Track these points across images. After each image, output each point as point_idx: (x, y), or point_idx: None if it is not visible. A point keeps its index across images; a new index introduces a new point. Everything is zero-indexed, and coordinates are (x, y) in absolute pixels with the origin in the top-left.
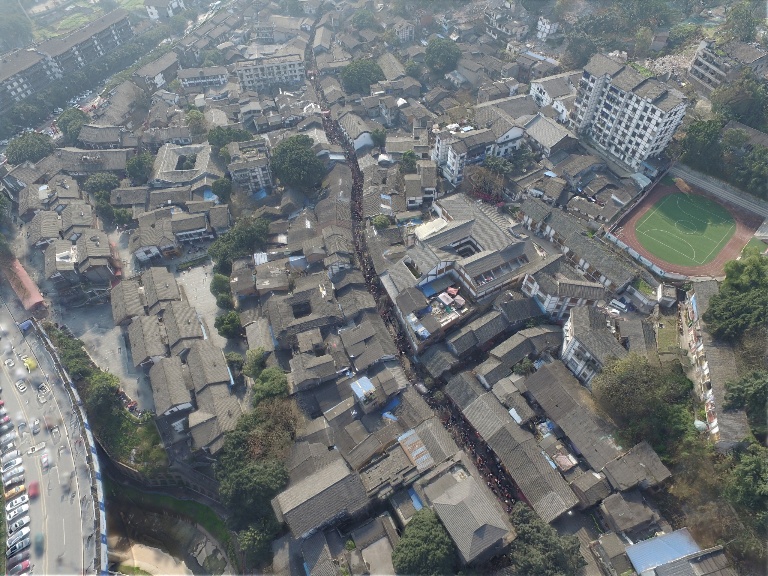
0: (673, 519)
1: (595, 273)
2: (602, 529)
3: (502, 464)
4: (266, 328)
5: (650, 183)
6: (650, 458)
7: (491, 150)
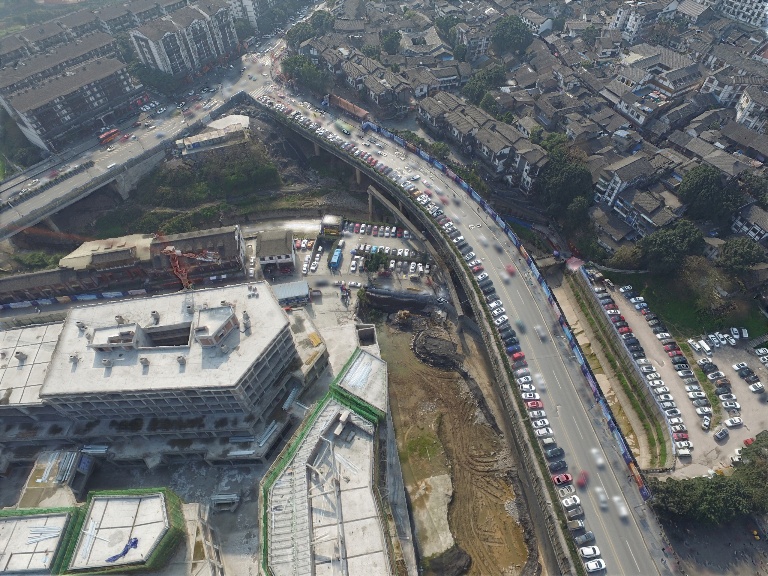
0: None
1: None
2: None
3: None
4: (533, 120)
5: None
6: None
7: (658, 17)
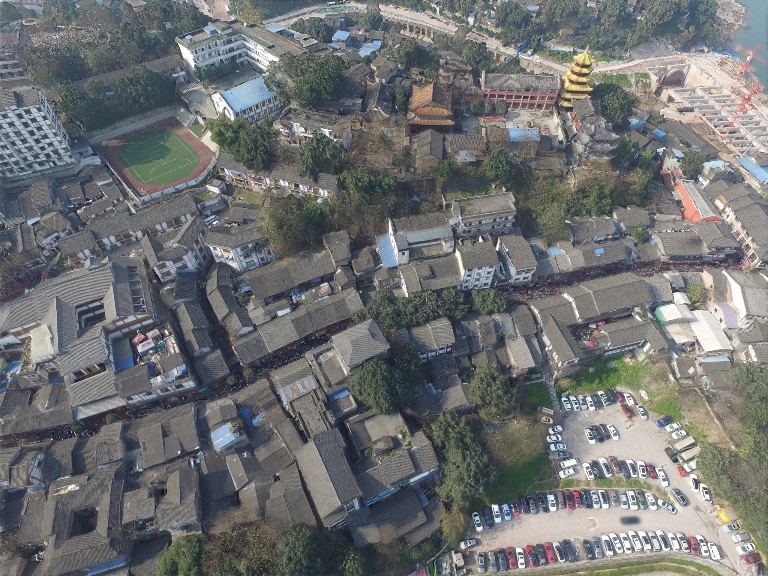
0: (369, 242)
1: (175, 222)
2: (370, 283)
3: (317, 335)
4: None
5: (99, 157)
6: (334, 236)
7: None
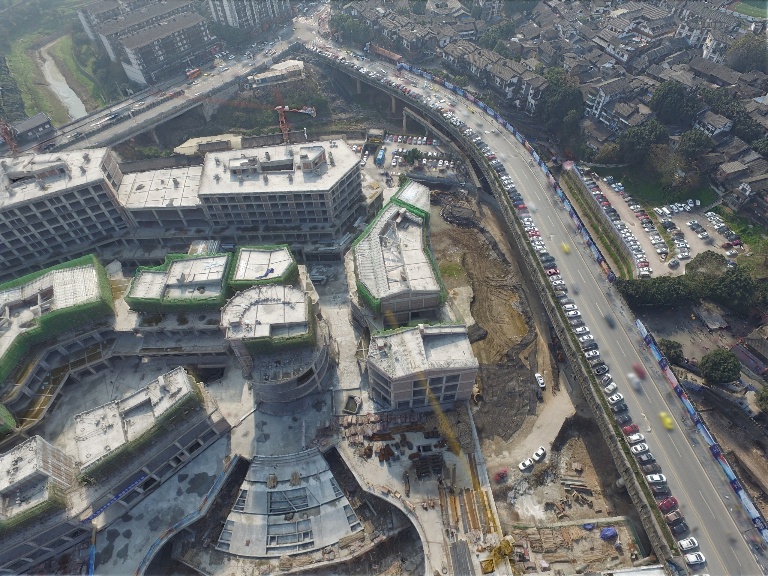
0: None
1: None
2: None
3: None
4: (537, 60)
5: None
6: (759, 73)
7: None
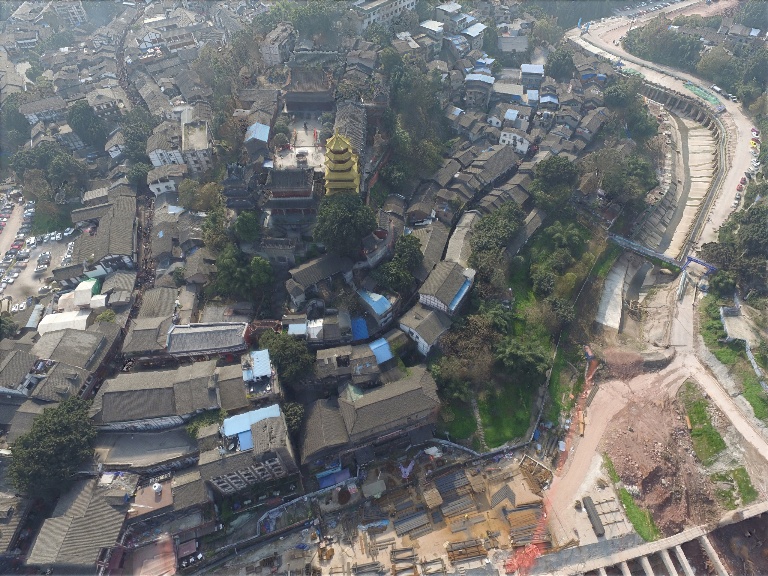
0: None
1: None
2: None
3: None
4: None
5: None
6: None
7: None
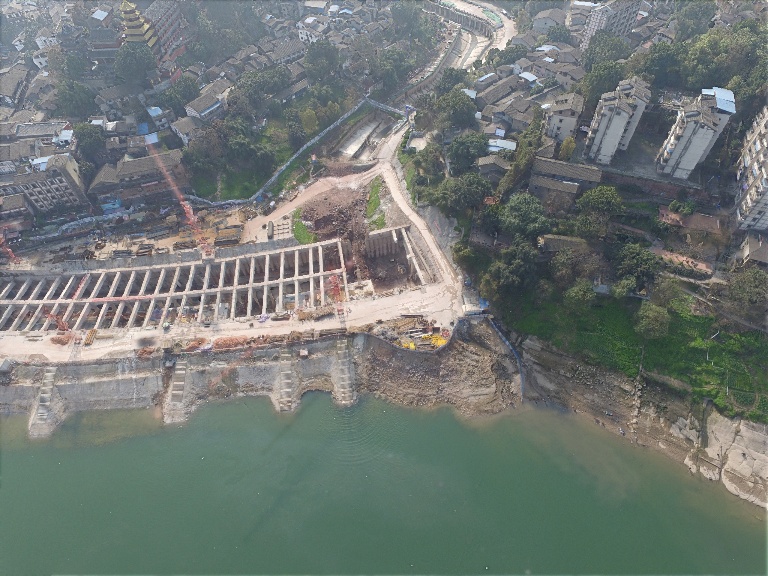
0: None
1: None
2: None
3: None
4: None
5: None
6: None
7: None
